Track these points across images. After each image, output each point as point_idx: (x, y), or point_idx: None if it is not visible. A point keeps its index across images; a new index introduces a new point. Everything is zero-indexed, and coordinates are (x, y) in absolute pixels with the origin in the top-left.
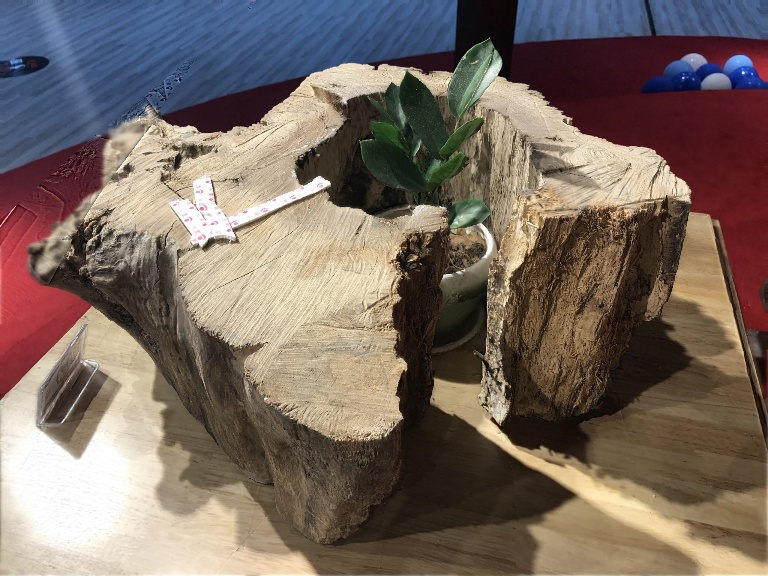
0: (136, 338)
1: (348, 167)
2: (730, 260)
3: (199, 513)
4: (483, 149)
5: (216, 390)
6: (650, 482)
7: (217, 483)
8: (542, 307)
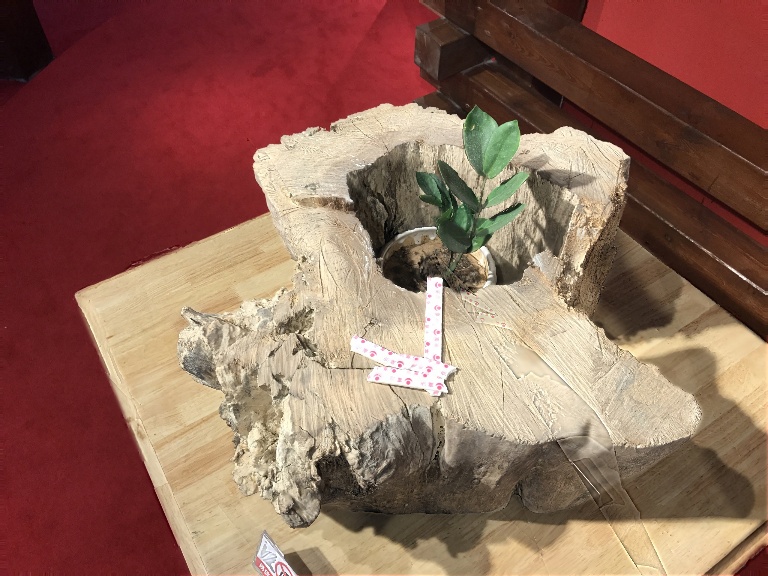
0: (335, 501)
1: None
2: None
3: (494, 561)
4: None
5: (517, 474)
6: (648, 324)
7: (477, 535)
8: (584, 269)
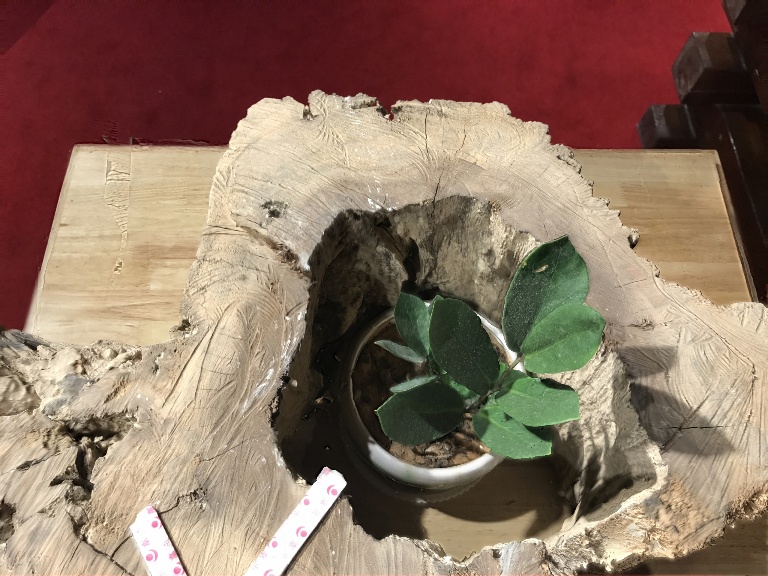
0: None
1: (315, 314)
2: (738, 221)
3: None
4: (504, 261)
5: None
6: None
7: None
8: None
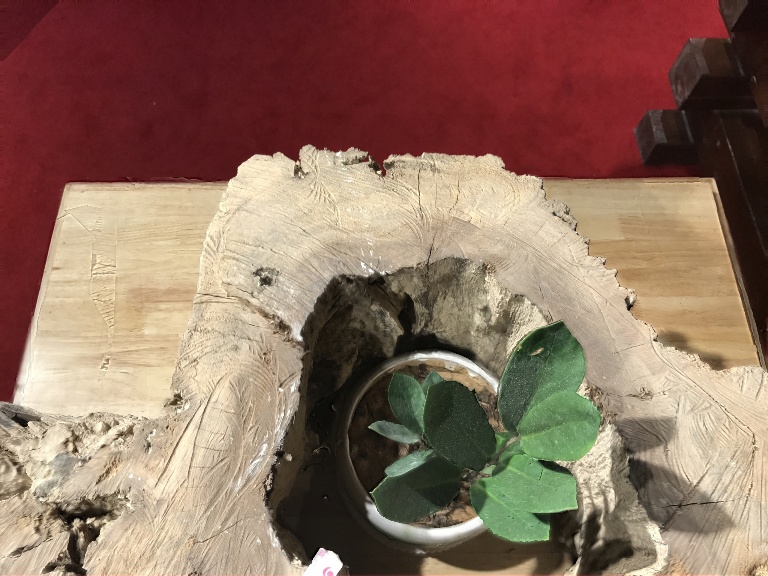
0: None
1: None
2: (737, 252)
3: None
4: (500, 319)
5: None
6: None
7: None
8: None
